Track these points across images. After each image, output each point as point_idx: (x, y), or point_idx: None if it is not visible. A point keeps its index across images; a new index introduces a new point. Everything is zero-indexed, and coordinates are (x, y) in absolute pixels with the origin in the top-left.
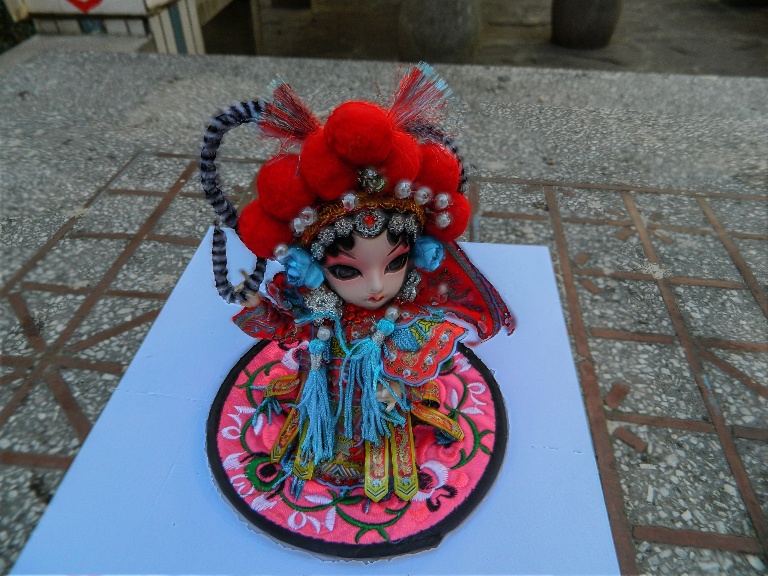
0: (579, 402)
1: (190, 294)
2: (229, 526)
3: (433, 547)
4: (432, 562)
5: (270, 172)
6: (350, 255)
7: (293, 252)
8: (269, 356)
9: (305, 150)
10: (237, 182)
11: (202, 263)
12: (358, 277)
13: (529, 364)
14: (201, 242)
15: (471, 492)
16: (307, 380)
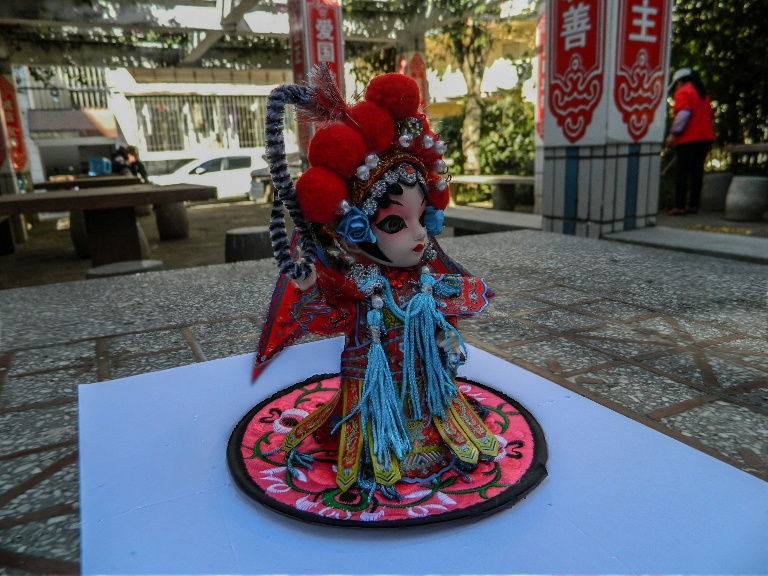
0: (537, 377)
1: (105, 431)
2: (351, 554)
3: (546, 475)
4: (555, 487)
5: (331, 130)
6: (399, 202)
7: (354, 206)
8: (258, 431)
9: (356, 110)
10: (78, 355)
11: (96, 409)
12: (403, 229)
13: (481, 371)
14: (78, 397)
15: (533, 436)
16: (369, 361)
